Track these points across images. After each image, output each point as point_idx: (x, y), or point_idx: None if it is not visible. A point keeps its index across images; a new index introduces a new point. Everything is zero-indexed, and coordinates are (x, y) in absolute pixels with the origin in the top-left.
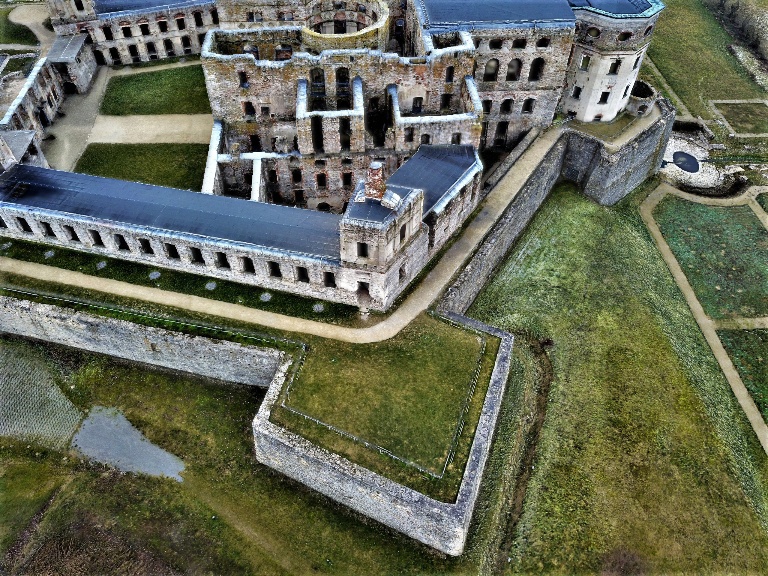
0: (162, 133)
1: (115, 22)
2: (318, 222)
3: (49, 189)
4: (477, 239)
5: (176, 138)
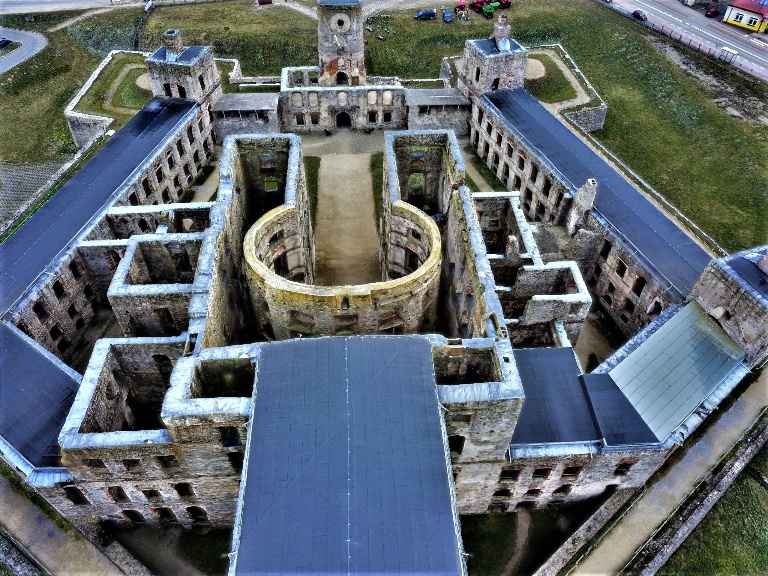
0: (336, 199)
1: (487, 112)
2: (4, 290)
3: (149, 122)
4: (1, 512)
5: (326, 210)
